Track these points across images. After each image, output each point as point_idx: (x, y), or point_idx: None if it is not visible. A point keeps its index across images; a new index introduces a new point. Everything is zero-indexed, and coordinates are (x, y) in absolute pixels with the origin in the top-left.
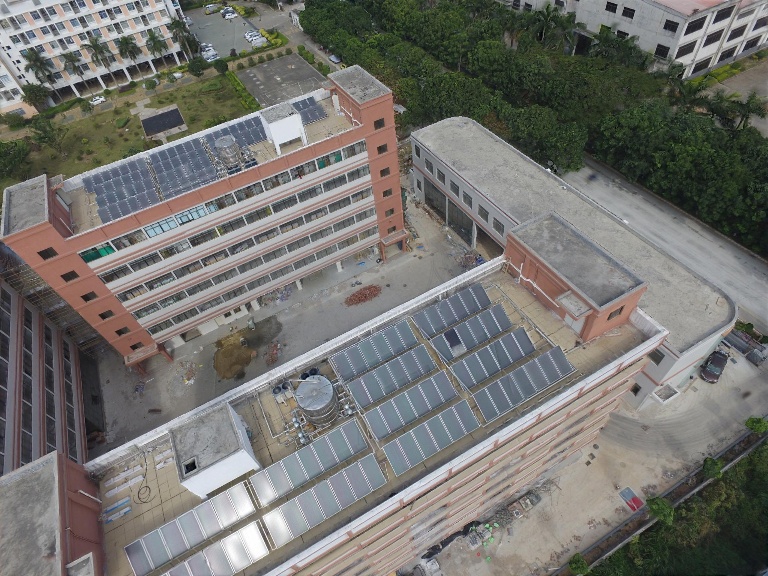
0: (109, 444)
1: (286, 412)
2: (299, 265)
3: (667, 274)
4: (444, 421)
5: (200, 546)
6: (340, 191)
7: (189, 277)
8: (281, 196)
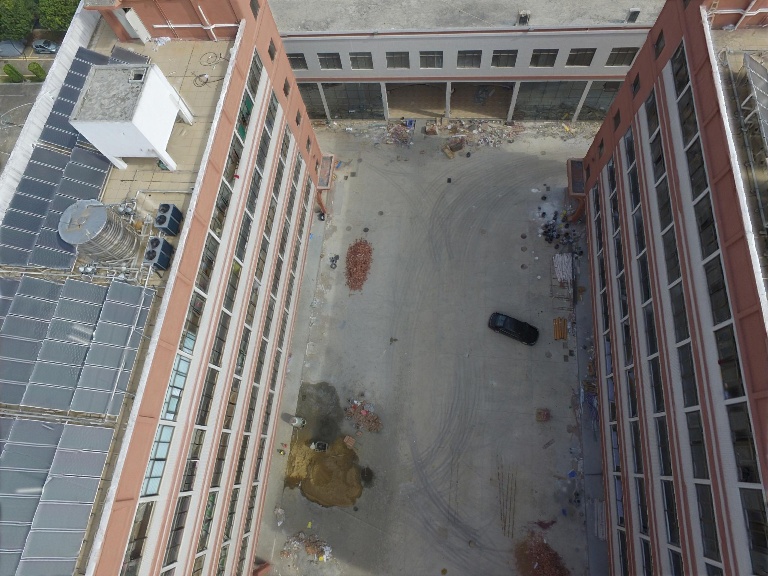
0: None
1: None
2: (287, 302)
3: None
4: None
5: None
6: (271, 158)
7: (226, 466)
8: (236, 229)
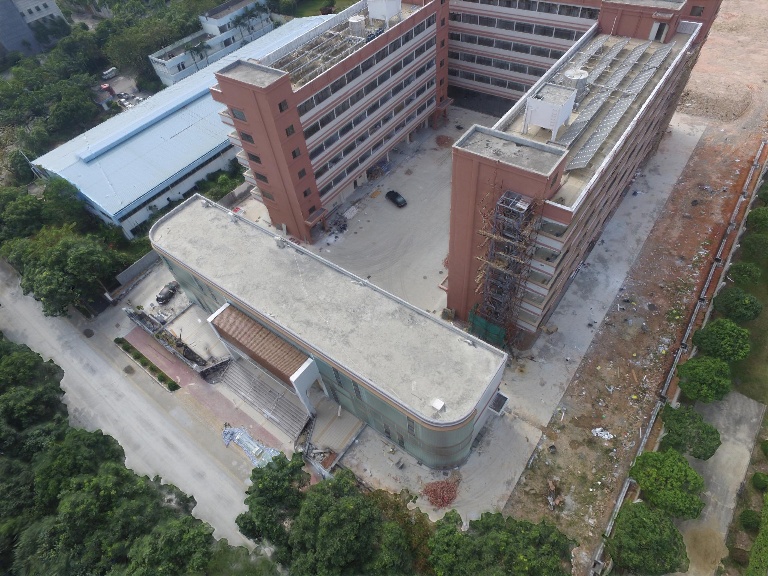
0: None
1: None
2: None
3: (189, 248)
4: None
5: None
6: None
7: None
8: None
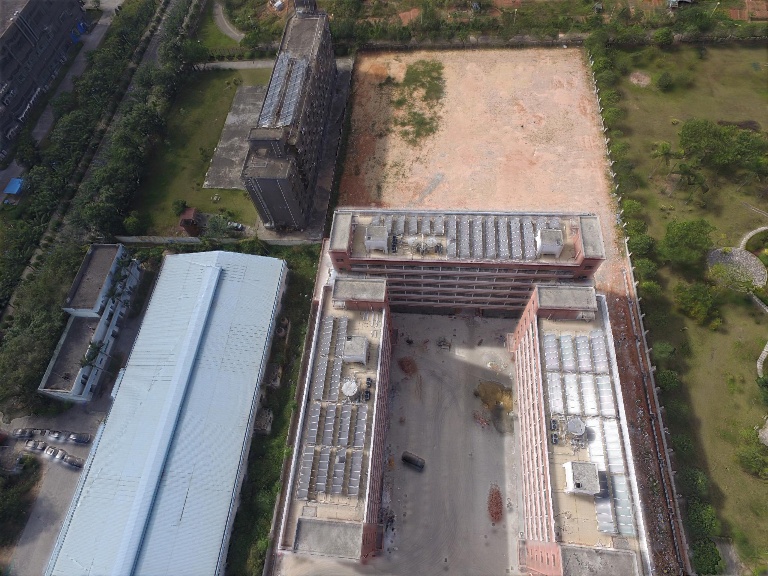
0: (473, 317)
1: (362, 381)
2: None
3: None
4: (314, 430)
5: (336, 337)
6: None
7: None
8: None
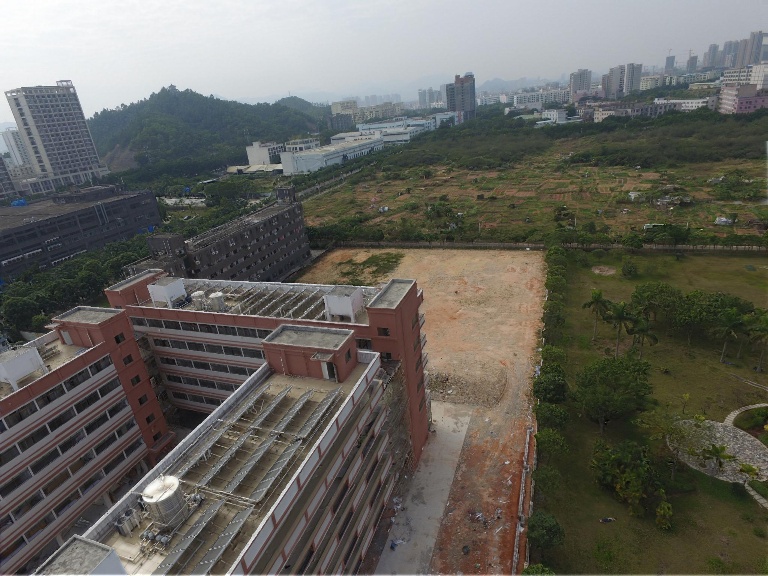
0: None
1: None
2: None
3: None
4: None
5: None
6: None
7: None
8: None
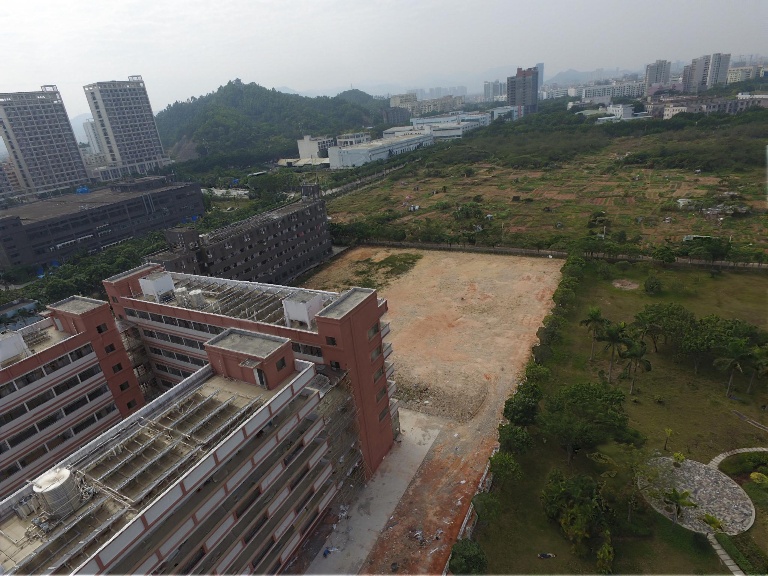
0: None
1: None
2: None
3: None
4: None
5: None
6: None
7: None
8: None
